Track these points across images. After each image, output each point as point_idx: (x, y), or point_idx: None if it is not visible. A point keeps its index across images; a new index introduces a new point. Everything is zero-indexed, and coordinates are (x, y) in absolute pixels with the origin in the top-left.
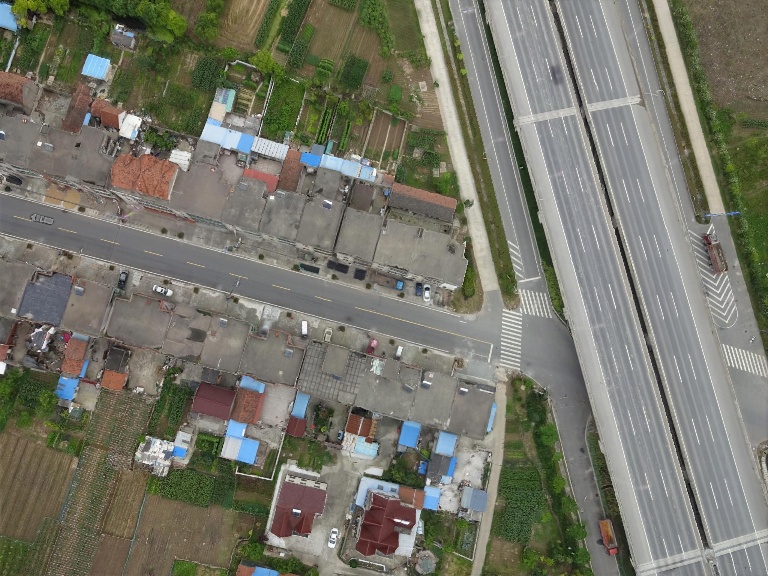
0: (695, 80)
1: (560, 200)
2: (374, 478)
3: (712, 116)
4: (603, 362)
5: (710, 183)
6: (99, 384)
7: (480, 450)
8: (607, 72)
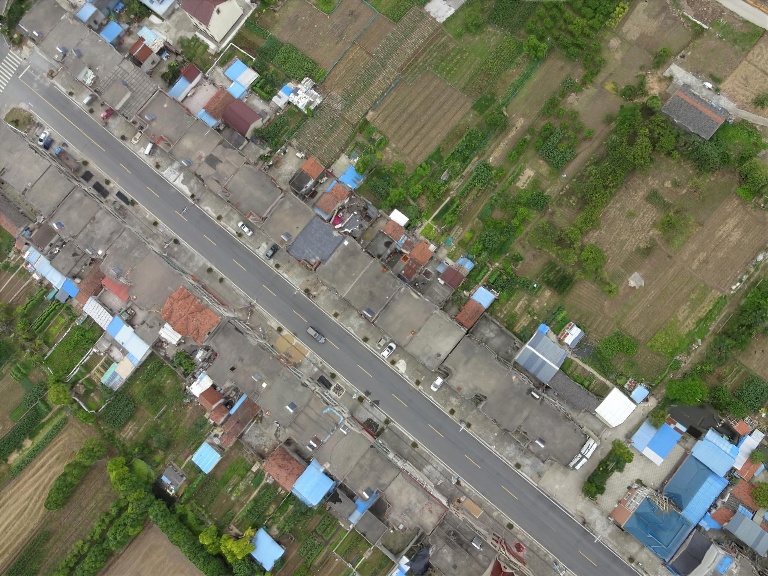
0: None
1: None
2: (156, 14)
3: None
4: None
5: None
6: None
7: (72, 3)
8: None
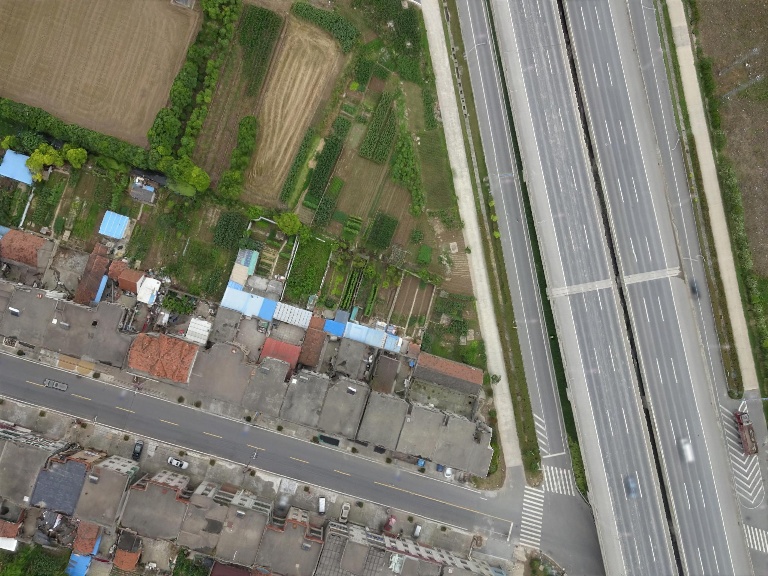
0: (737, 245)
1: (591, 380)
2: None
3: (752, 286)
4: (625, 553)
5: (745, 355)
6: (111, 560)
7: None
8: (647, 241)
